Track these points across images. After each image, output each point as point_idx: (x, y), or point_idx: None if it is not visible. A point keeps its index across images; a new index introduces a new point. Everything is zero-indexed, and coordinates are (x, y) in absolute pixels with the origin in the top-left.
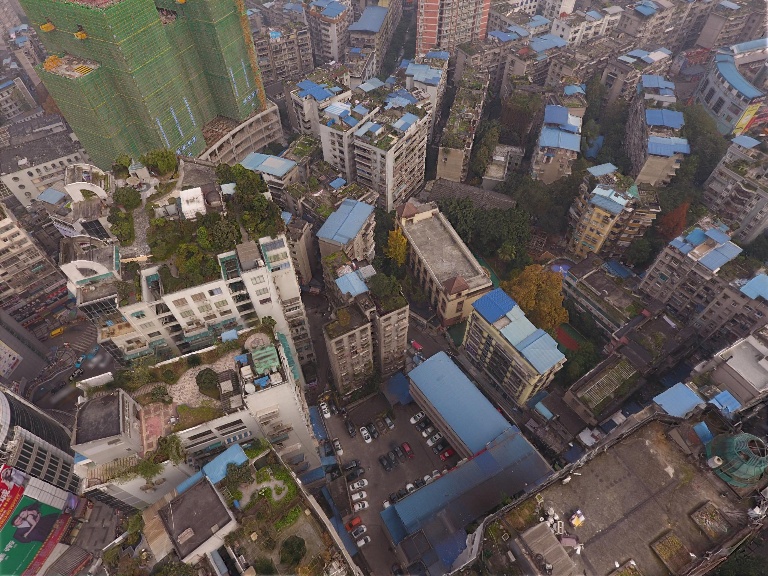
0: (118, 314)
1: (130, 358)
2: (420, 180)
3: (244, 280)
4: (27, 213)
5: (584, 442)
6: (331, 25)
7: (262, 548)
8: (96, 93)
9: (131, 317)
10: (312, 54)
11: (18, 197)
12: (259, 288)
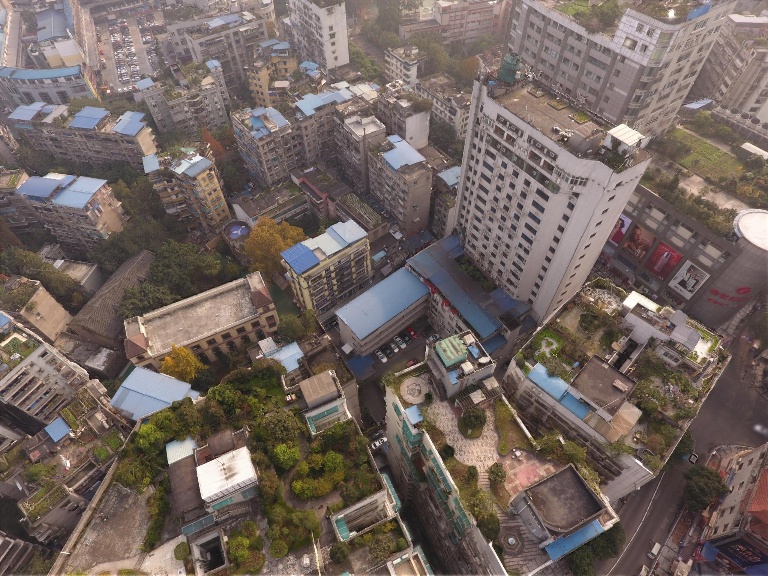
0: None
1: None
2: None
3: None
4: None
5: (400, 238)
6: None
7: (594, 347)
8: None
9: None
10: None
11: None
12: None
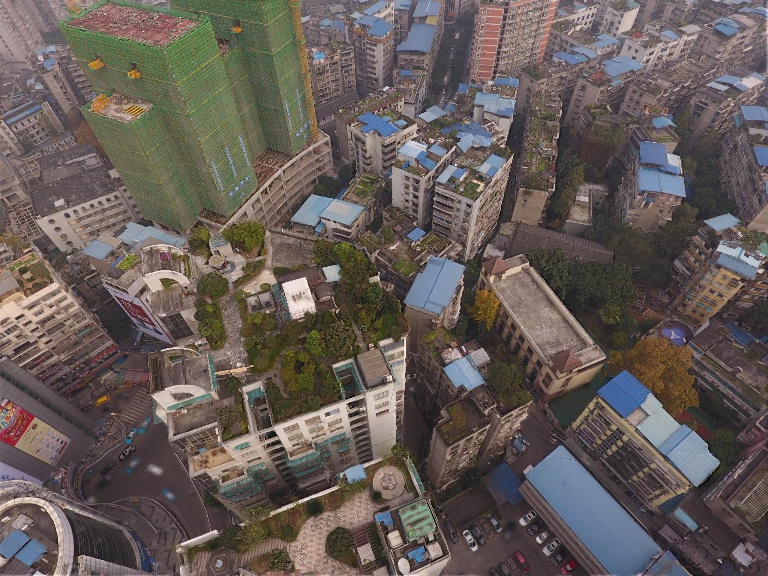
0: (214, 441)
1: (226, 490)
2: (495, 223)
3: (367, 398)
4: (67, 263)
5: (738, 560)
6: (378, 45)
7: None
8: (149, 136)
9: (234, 450)
10: (355, 75)
11: (53, 240)
12: (380, 402)
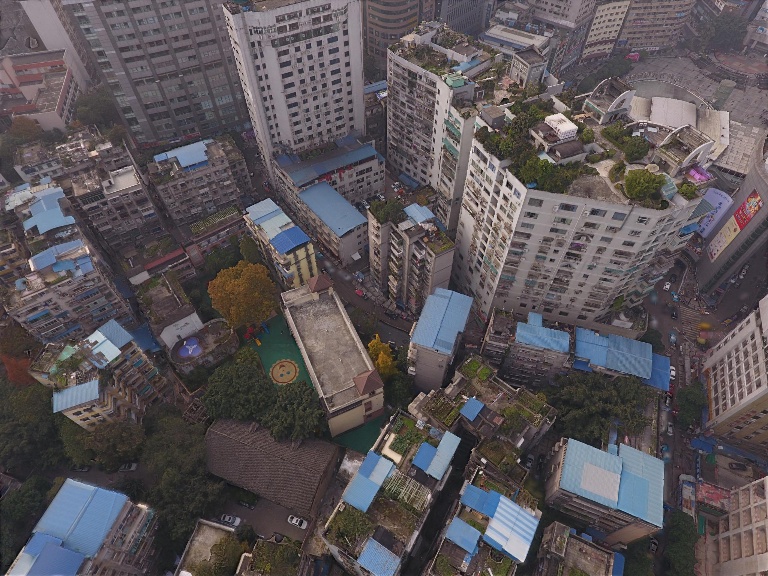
0: None
1: None
2: None
3: None
4: None
5: None
6: None
7: None
8: None
9: None
10: None
11: None
12: None
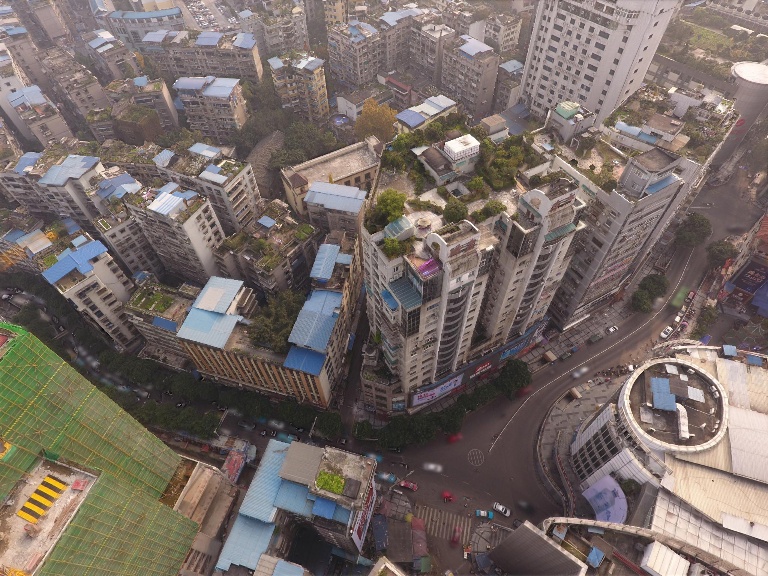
0: None
1: None
2: None
3: None
4: None
5: None
6: None
7: None
8: None
9: None
10: None
11: None
12: None
